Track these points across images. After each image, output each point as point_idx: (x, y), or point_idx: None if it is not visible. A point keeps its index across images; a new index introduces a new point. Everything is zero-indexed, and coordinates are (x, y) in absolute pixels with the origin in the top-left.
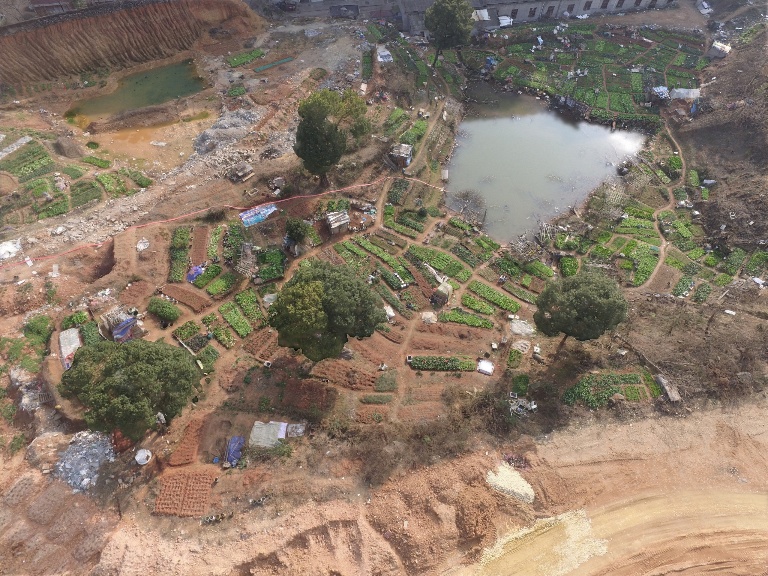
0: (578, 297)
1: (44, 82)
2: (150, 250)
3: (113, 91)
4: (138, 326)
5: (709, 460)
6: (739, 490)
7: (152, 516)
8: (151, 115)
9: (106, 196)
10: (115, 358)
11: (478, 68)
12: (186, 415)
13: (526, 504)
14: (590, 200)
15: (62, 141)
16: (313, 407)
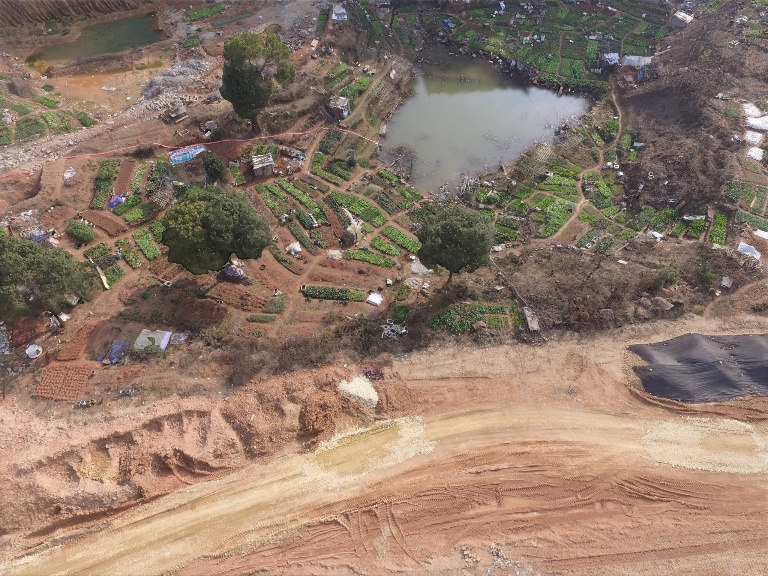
0: (444, 227)
1: (10, 28)
2: (75, 178)
3: (75, 39)
4: (50, 242)
5: (551, 382)
6: (571, 408)
7: (31, 399)
8: (107, 62)
9: (49, 132)
10: None
11: (436, 31)
12: (81, 320)
13: (369, 408)
14: (520, 159)
15: (15, 81)
16: (201, 322)
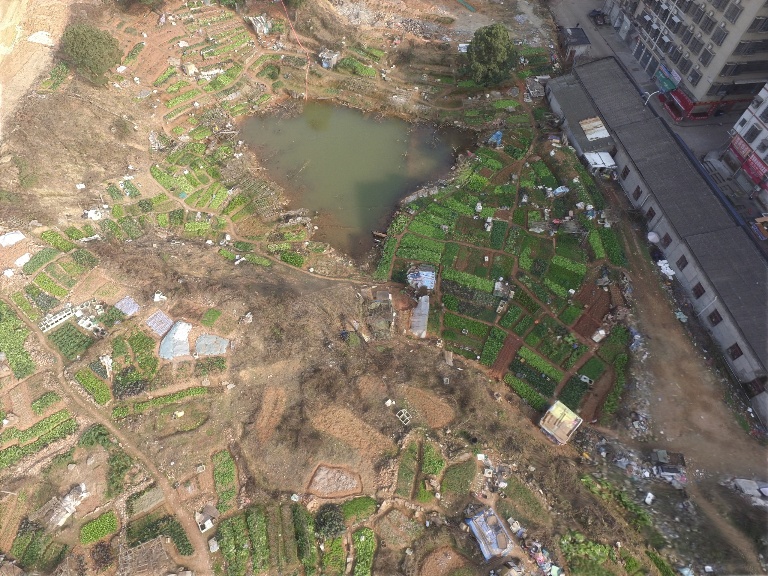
0: None
1: None
2: None
3: None
4: None
5: None
6: None
7: None
8: None
9: None
10: None
11: None
12: None
13: None
14: None
15: None
16: None
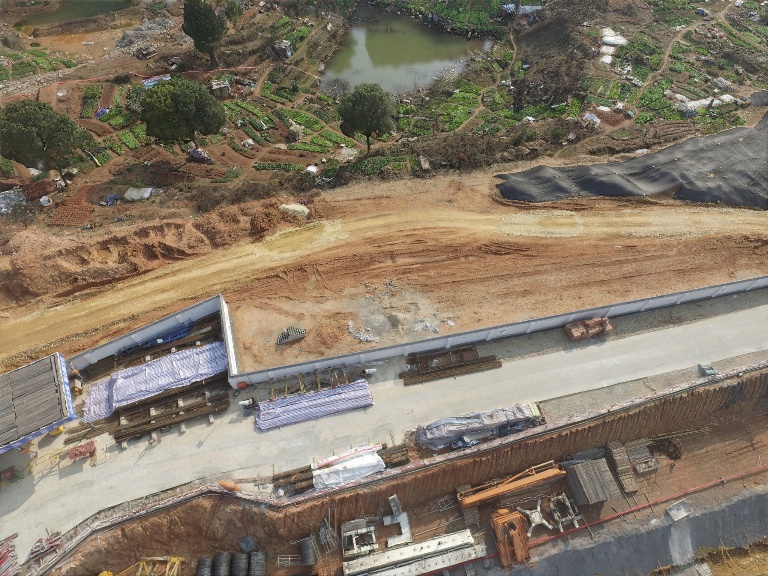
0: (354, 94)
1: None
2: (67, 96)
3: (55, 9)
4: None
5: (436, 196)
6: (449, 209)
7: (48, 227)
8: (84, 24)
9: (40, 71)
10: (15, 104)
11: None
12: (81, 184)
13: (302, 217)
14: None
15: (8, 36)
16: None
